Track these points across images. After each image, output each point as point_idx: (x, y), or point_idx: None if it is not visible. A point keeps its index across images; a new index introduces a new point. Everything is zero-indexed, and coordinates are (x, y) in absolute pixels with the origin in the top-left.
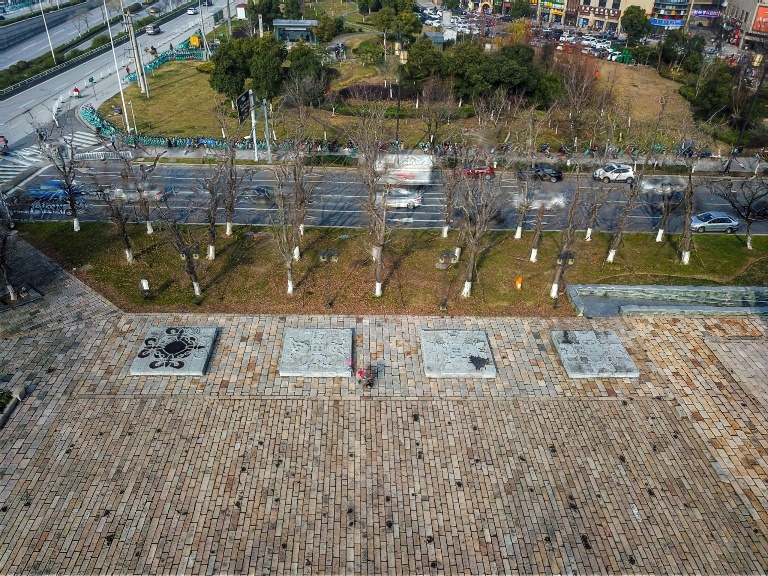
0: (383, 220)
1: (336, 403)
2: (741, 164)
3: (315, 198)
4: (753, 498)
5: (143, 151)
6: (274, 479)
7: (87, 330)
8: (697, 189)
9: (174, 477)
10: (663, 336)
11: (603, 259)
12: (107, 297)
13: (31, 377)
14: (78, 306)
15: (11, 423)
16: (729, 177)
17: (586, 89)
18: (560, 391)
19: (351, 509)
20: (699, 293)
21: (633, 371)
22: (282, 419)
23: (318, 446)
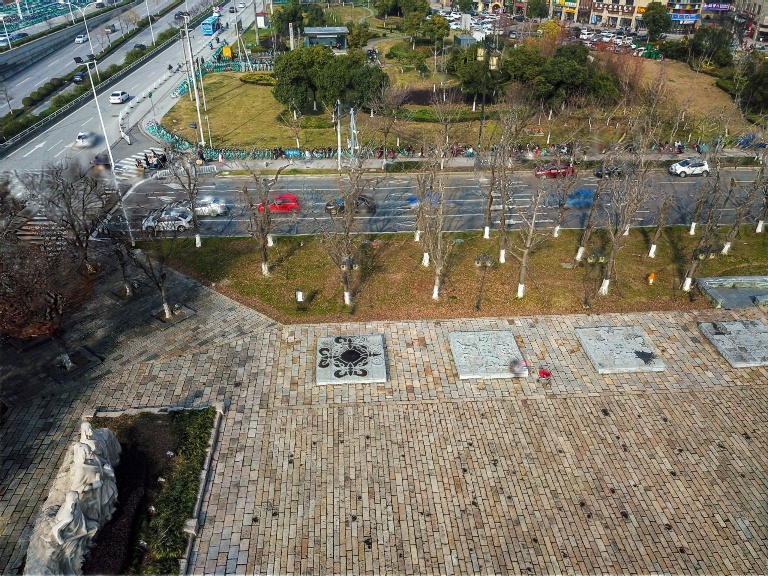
0: (532, 223)
1: (524, 402)
2: None
3: (411, 204)
4: None
5: (224, 165)
6: (498, 478)
7: (255, 343)
8: None
9: (403, 481)
10: None
11: (717, 252)
12: (259, 310)
13: (222, 392)
14: (234, 320)
15: (223, 437)
16: None
17: (662, 87)
18: (730, 381)
19: (583, 502)
20: None
21: None
22: (480, 420)
23: (525, 444)
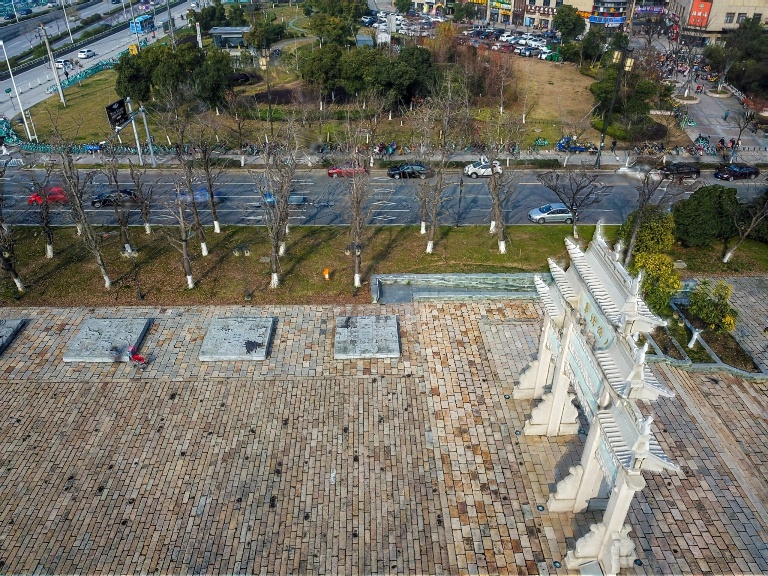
0: (180, 217)
1: (104, 385)
2: (617, 157)
3: None
4: (447, 462)
5: None
6: (15, 452)
7: None
8: (562, 182)
9: None
10: (442, 320)
11: (424, 250)
12: None
13: None
14: None
15: None
16: (599, 170)
17: None
18: (319, 371)
19: (73, 476)
20: (498, 280)
21: (393, 352)
22: (48, 400)
23: (69, 423)
